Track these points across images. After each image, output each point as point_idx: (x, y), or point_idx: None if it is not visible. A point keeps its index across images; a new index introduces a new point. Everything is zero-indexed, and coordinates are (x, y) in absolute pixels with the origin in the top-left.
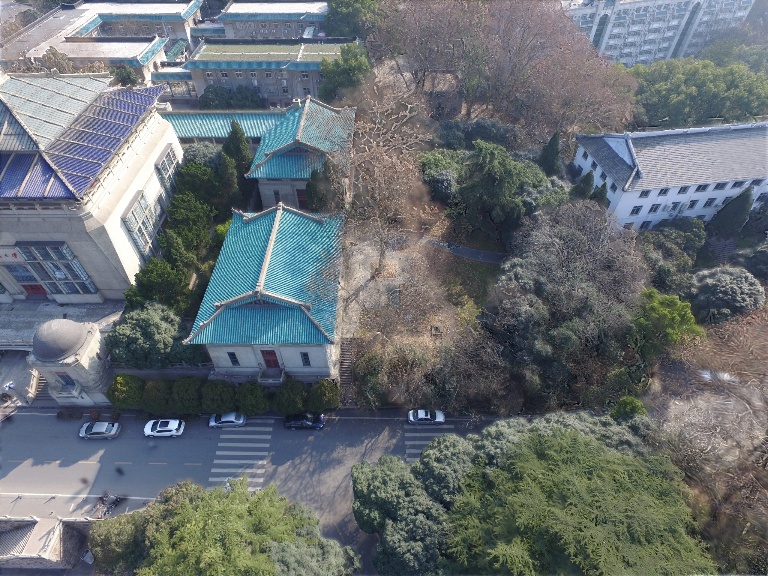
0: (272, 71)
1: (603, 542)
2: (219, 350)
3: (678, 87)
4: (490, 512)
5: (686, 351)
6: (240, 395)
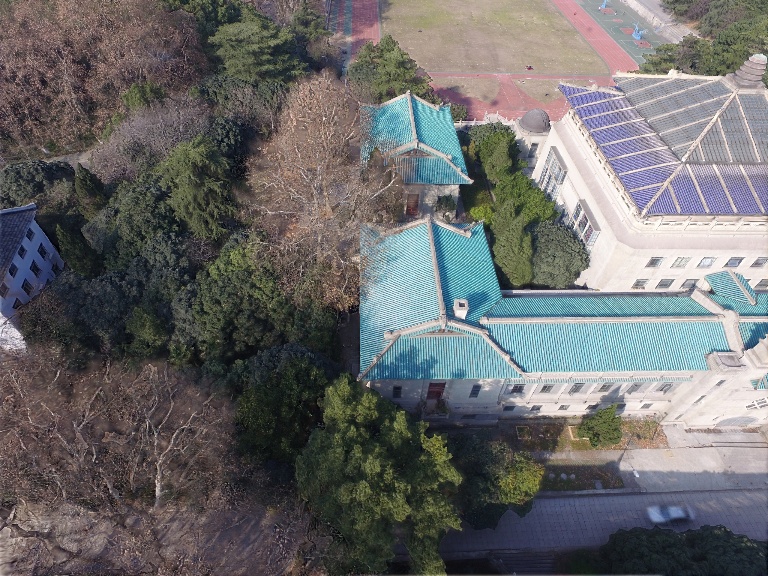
0: None
1: None
2: None
3: None
4: (288, 63)
5: None
6: None
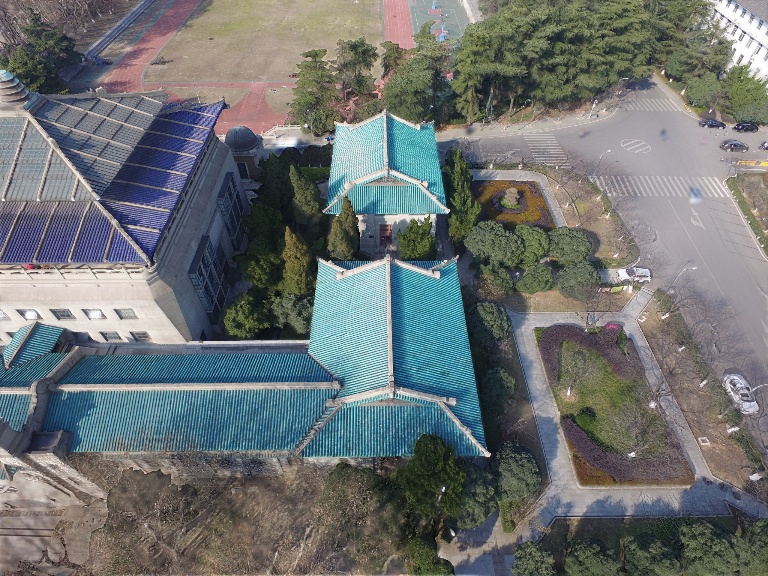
0: None
1: None
2: None
3: None
4: None
5: None
6: None
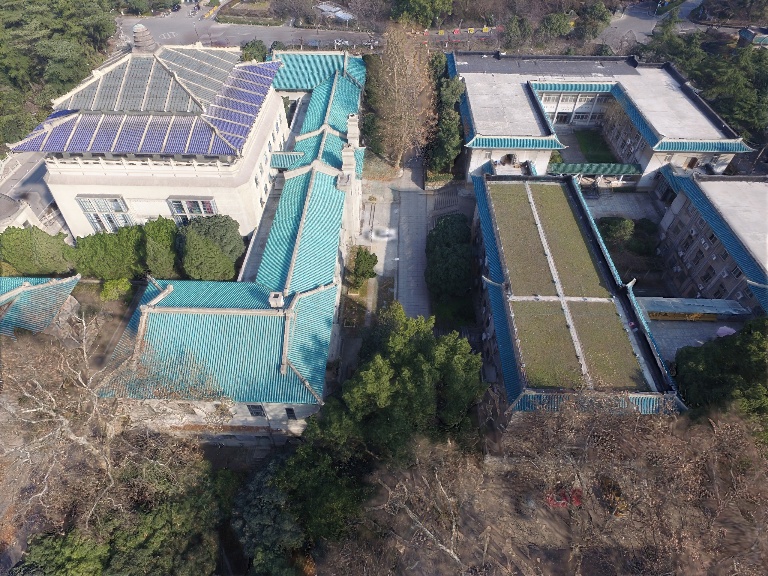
0: None
1: None
2: None
3: None
4: None
5: None
6: None
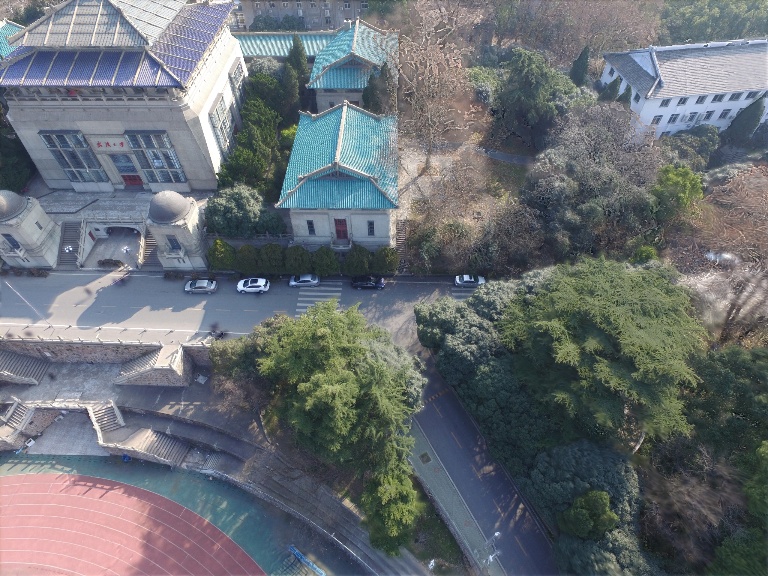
0: (317, 1)
1: (622, 315)
2: (300, 218)
3: (702, 10)
4: (532, 315)
5: (694, 215)
6: (317, 257)
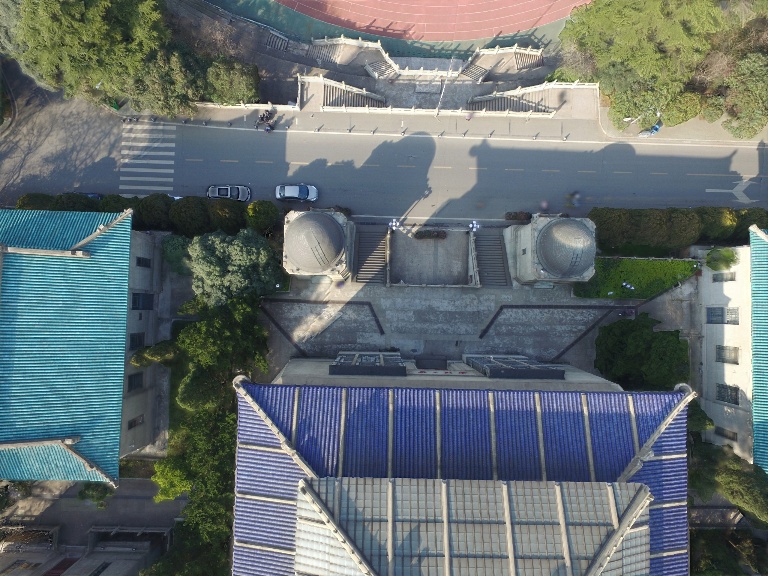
0: None
1: None
2: None
3: None
4: None
5: None
6: (124, 205)
